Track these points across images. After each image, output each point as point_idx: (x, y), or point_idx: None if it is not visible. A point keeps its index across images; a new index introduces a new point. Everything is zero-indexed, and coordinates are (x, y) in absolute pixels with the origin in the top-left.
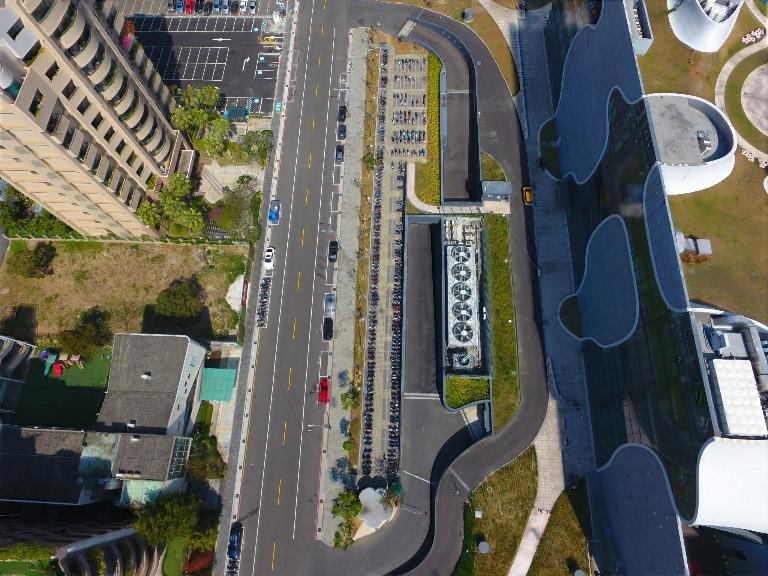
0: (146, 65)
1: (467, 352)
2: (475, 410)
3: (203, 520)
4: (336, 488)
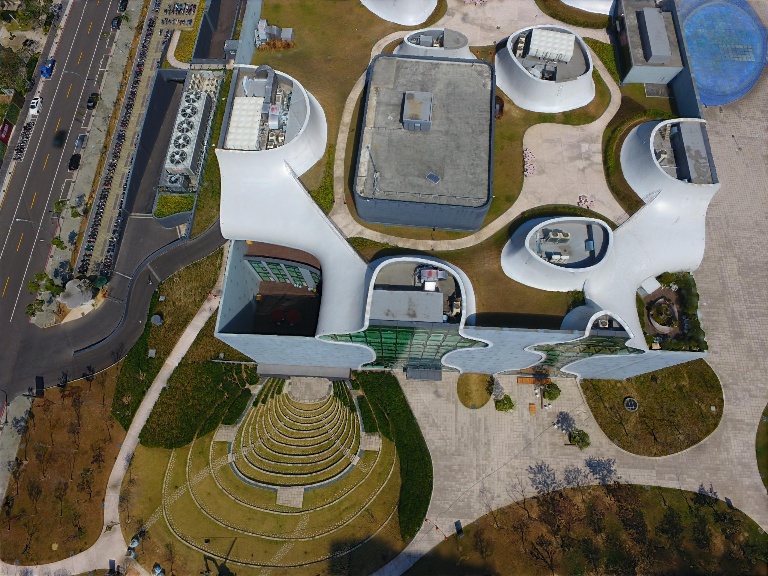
0: None
1: (190, 180)
2: None
3: None
4: (55, 284)
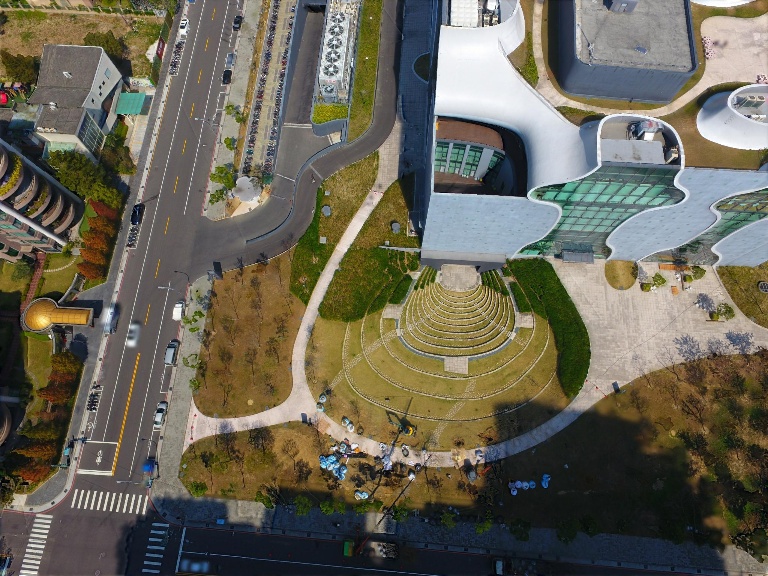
0: None
1: None
2: (339, 135)
3: None
4: None
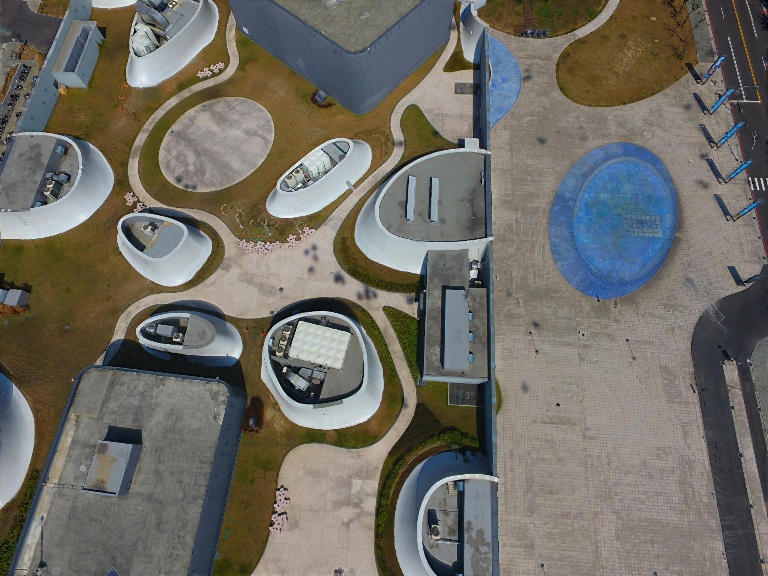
0: None
1: None
2: None
3: None
4: None
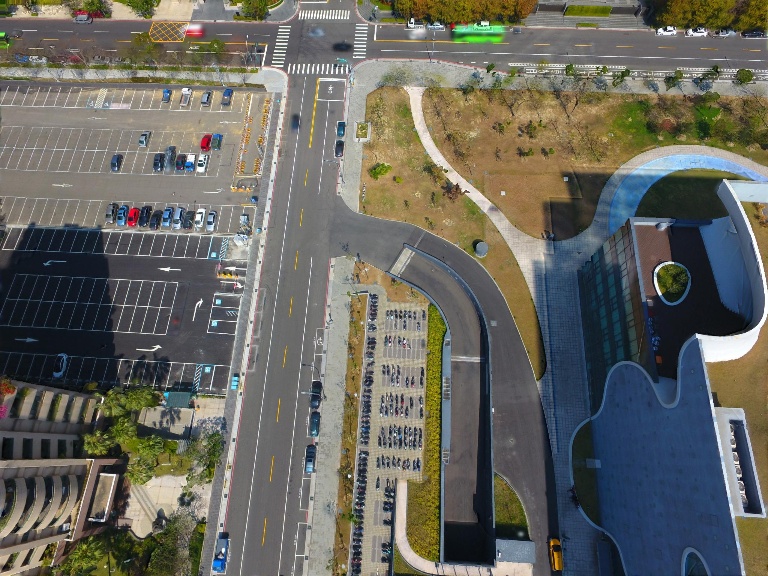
0: (41, 403)
1: None
2: None
3: None
4: None
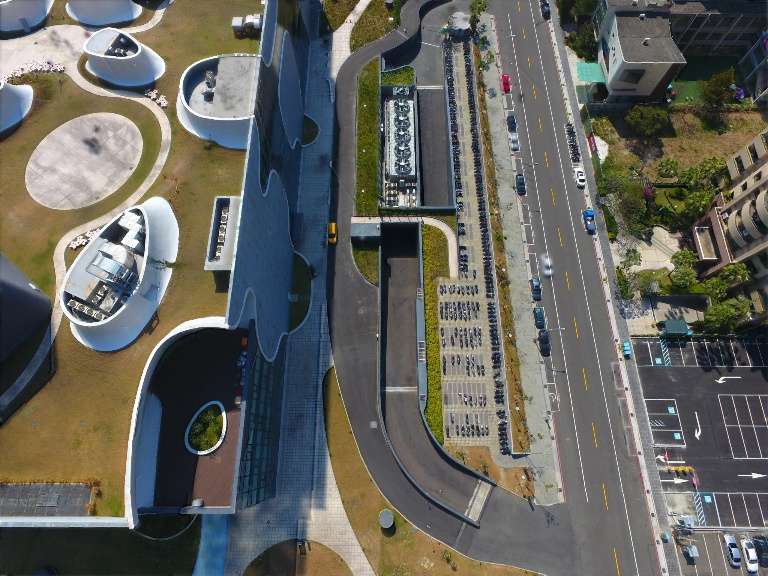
0: None
1: None
2: None
3: (571, 7)
4: None
